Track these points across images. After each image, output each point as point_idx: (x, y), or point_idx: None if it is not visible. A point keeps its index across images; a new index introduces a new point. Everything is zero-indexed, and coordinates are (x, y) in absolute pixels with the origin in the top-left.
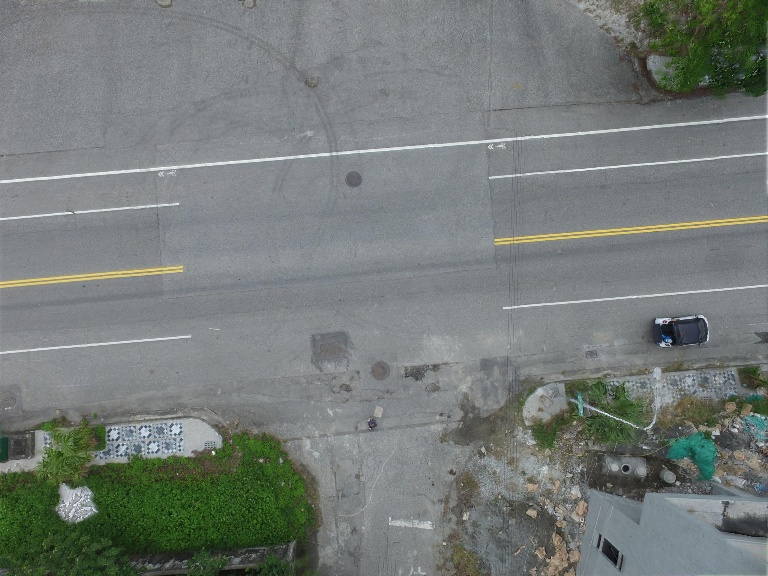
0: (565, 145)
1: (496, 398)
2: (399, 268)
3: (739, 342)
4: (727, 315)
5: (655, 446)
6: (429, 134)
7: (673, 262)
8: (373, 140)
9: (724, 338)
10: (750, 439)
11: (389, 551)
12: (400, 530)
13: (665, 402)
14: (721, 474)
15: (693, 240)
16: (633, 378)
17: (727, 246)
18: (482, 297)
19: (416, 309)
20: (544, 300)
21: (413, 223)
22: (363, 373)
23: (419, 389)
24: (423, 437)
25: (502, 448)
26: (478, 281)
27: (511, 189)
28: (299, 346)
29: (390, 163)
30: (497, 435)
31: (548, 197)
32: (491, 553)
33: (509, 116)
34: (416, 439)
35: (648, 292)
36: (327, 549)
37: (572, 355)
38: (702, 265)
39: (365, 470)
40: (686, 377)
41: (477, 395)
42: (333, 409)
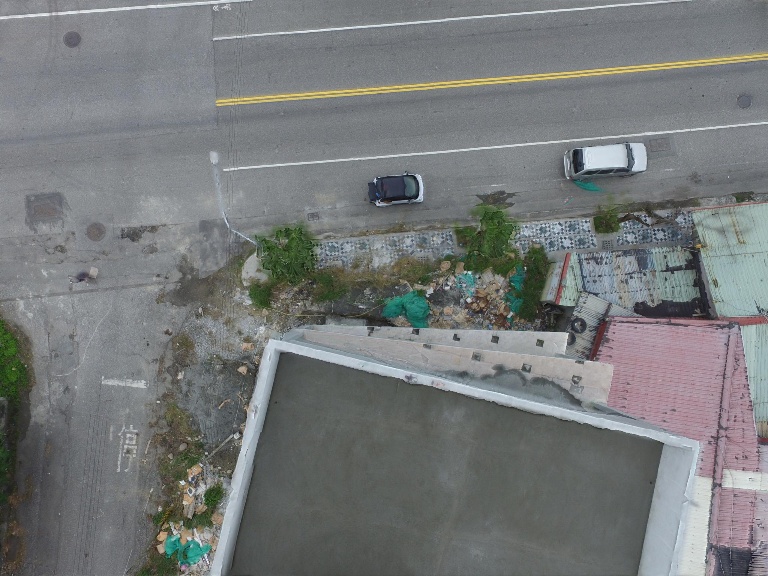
0: (292, 7)
1: (215, 260)
2: (117, 129)
3: (460, 204)
4: (449, 177)
5: (370, 305)
6: None
7: (396, 124)
8: (95, 0)
9: (446, 200)
10: (460, 296)
11: (100, 409)
12: (113, 389)
13: (383, 262)
14: None
15: (416, 102)
16: (353, 239)
17: (450, 108)
18: (202, 159)
19: (134, 170)
20: (266, 162)
21: (133, 84)
22: (78, 234)
23: (136, 250)
24: (139, 298)
25: (219, 309)
26: (198, 143)
27: (233, 50)
28: (13, 207)
29: (111, 24)
30: (215, 296)
31: (272, 59)
32: (199, 408)
33: None
34: (132, 300)
35: (370, 154)
36: (39, 408)
37: (293, 217)
38: (425, 127)
39: (79, 330)
40: (405, 238)
41: (196, 257)
42: (47, 270)
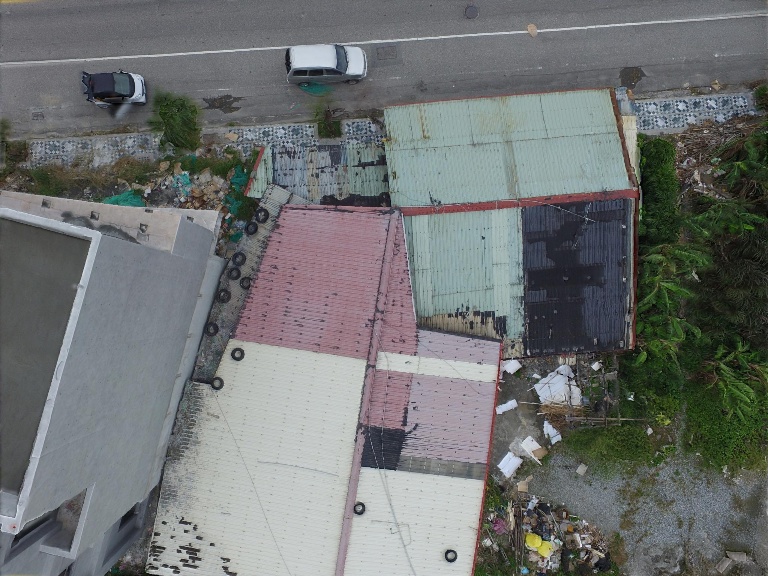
0: None
1: None
2: None
3: None
4: (175, 80)
5: None
6: None
7: (123, 26)
8: None
9: None
10: (175, 195)
11: None
12: None
13: (103, 162)
14: None
15: (144, 5)
16: (75, 139)
17: (178, 12)
18: None
19: None
20: None
21: None
22: None
23: None
24: None
25: None
26: None
27: None
28: None
29: None
30: None
31: None
32: None
33: None
34: None
35: (95, 55)
36: None
37: None
38: (152, 30)
39: None
40: (127, 138)
41: None
42: None
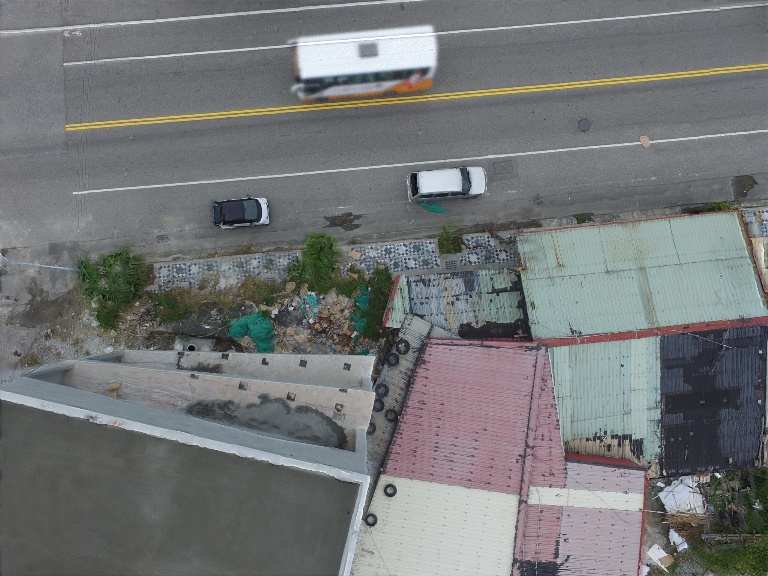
0: (142, 32)
1: (65, 282)
2: None
3: (308, 226)
4: (296, 200)
5: (217, 326)
6: (4, 20)
7: (244, 148)
8: None
9: (293, 222)
10: (303, 316)
11: None
12: None
13: (230, 283)
14: (280, 351)
15: (264, 126)
16: (201, 261)
17: (298, 132)
18: (51, 182)
19: None
20: (115, 185)
21: None
22: None
23: None
24: None
25: (68, 330)
26: (48, 166)
27: (83, 75)
28: None
29: None
30: (64, 317)
31: (122, 84)
32: None
33: (86, 3)
34: None
35: (218, 177)
36: None
37: (142, 239)
38: (273, 151)
39: None
40: (252, 259)
41: (45, 279)
42: None
